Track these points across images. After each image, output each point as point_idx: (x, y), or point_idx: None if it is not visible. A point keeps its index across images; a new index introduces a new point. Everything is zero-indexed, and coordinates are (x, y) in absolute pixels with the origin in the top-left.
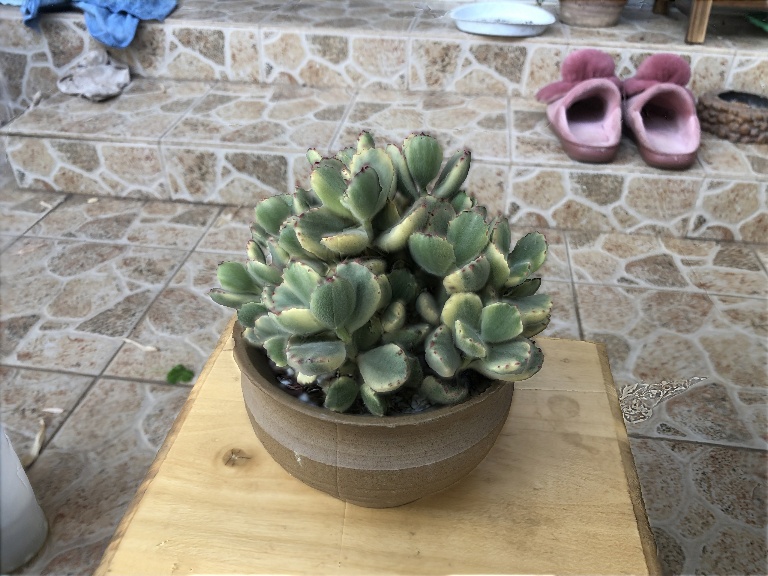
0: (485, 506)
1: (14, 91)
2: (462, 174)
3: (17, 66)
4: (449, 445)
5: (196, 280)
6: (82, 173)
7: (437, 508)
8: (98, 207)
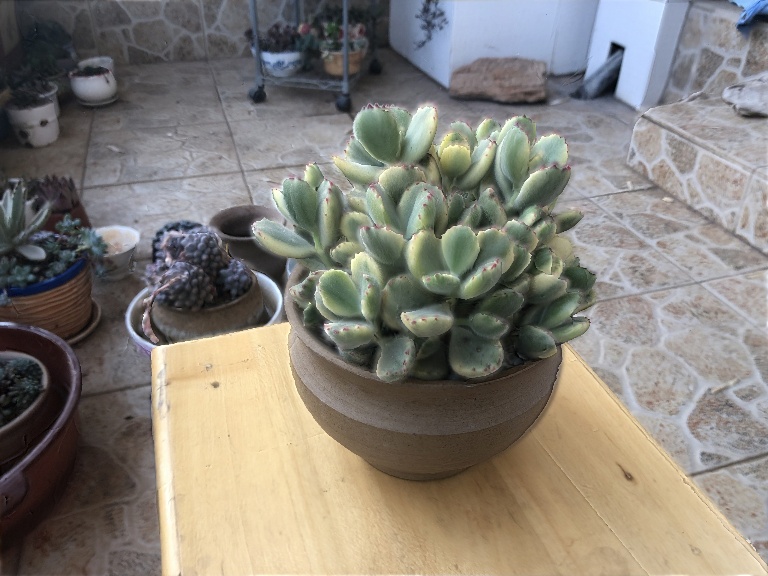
0: (406, 527)
1: (696, 87)
2: (537, 186)
3: (711, 66)
4: (342, 401)
5: (670, 306)
6: (676, 172)
7: (380, 489)
8: (666, 207)
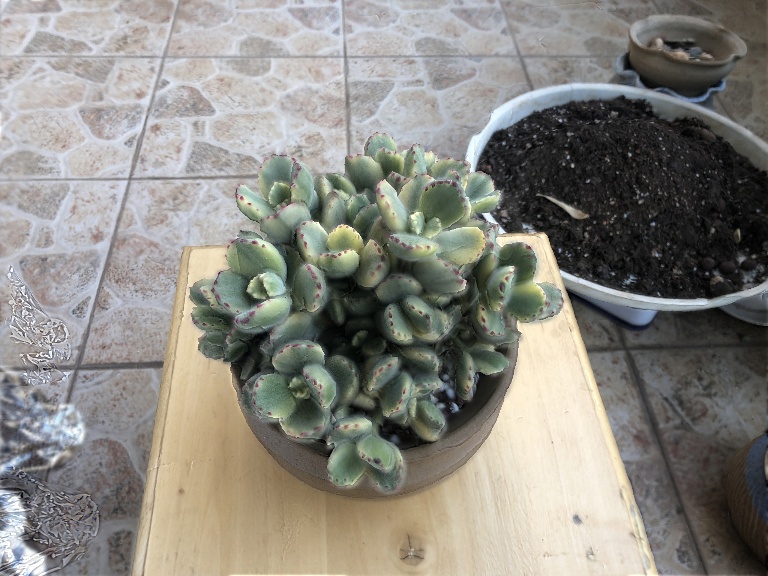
0: None
1: None
2: None
3: None
4: None
5: None
6: None
7: None
8: None
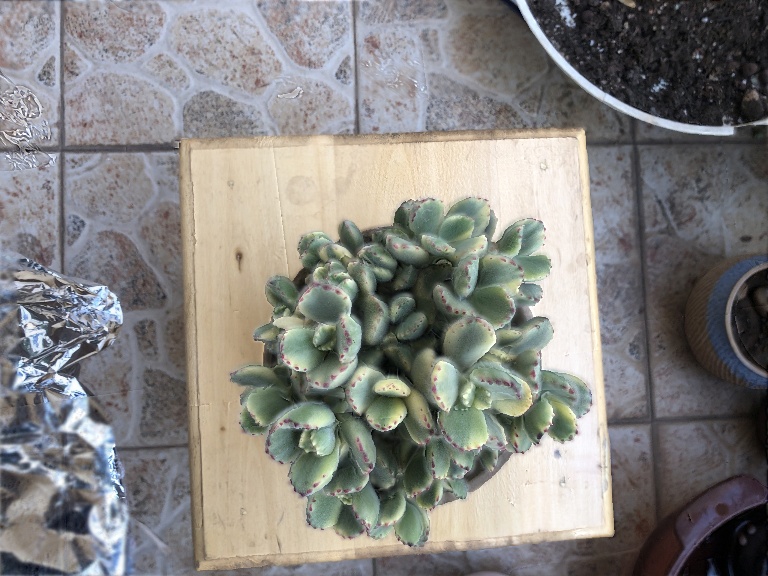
0: None
1: None
2: None
3: None
4: None
5: None
6: None
7: None
8: None
